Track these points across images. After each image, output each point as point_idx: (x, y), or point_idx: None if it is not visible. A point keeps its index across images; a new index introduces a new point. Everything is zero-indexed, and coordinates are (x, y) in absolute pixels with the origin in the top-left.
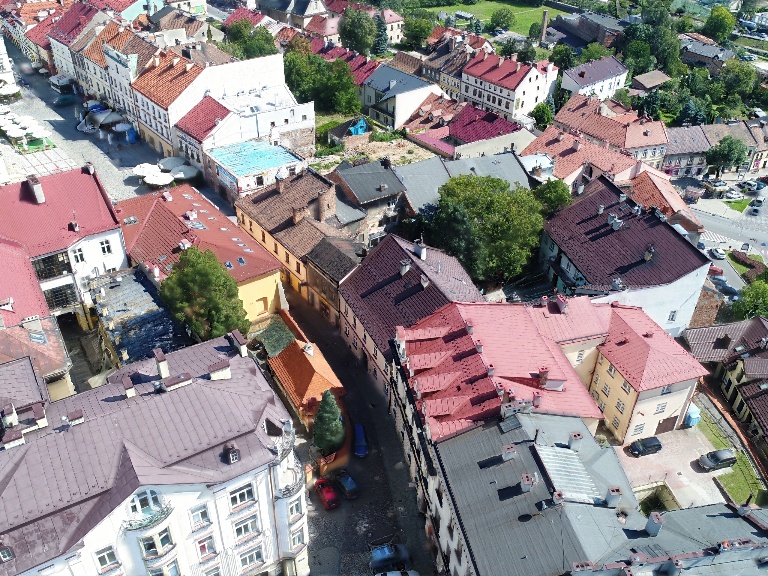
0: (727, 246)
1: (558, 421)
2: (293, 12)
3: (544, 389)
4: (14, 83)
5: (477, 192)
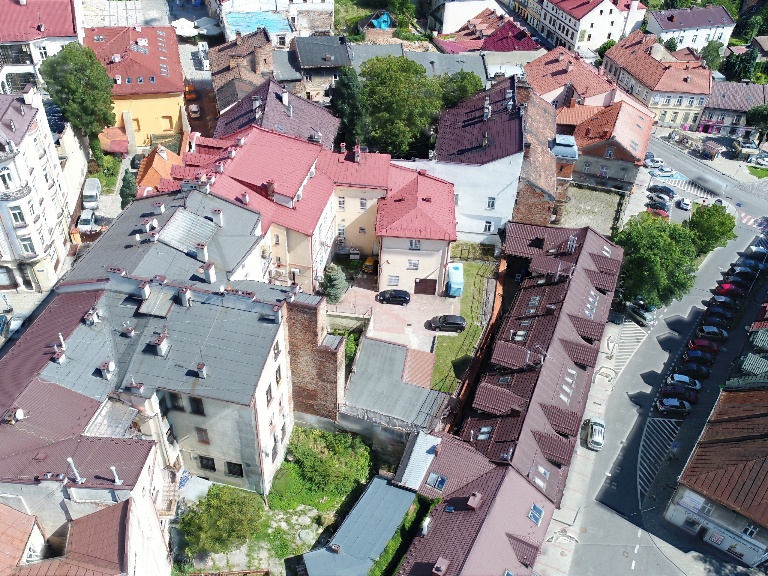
0: (705, 201)
1: (231, 208)
2: None
3: (275, 202)
4: None
5: (381, 66)
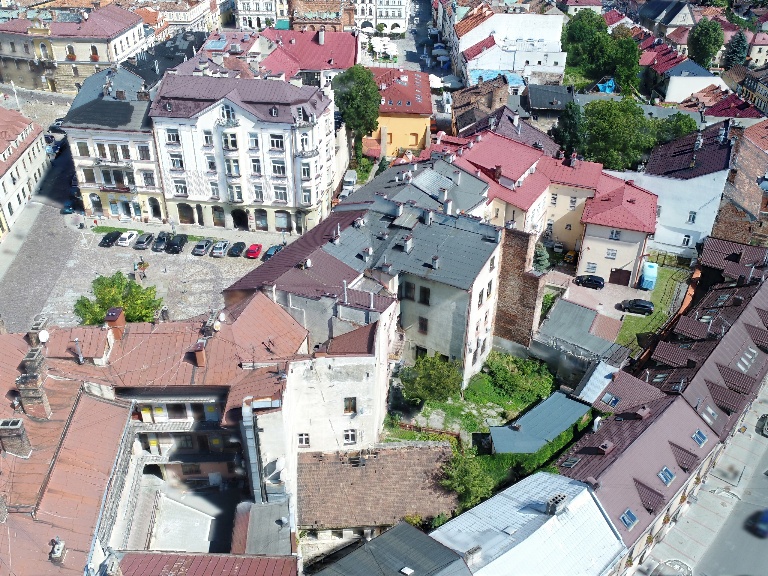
0: None
1: (467, 176)
2: (661, 21)
3: (500, 184)
4: (404, 28)
5: (603, 104)
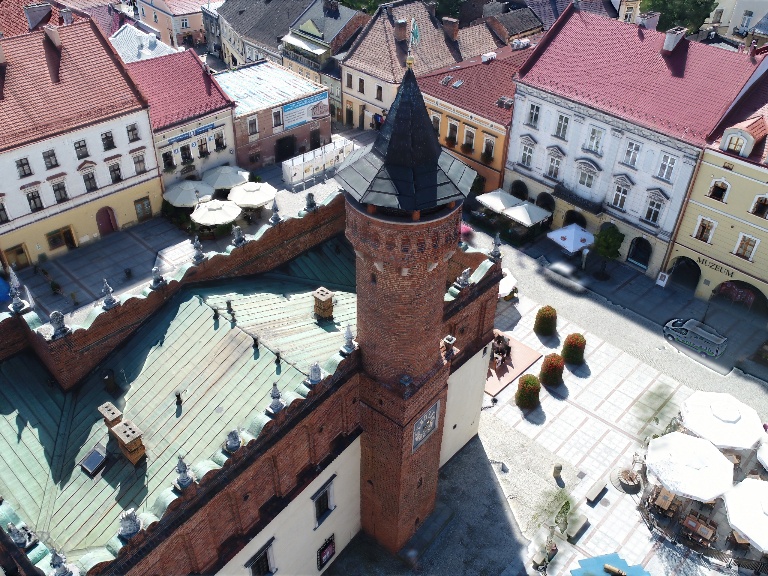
0: None
1: None
2: None
3: None
4: None
5: None
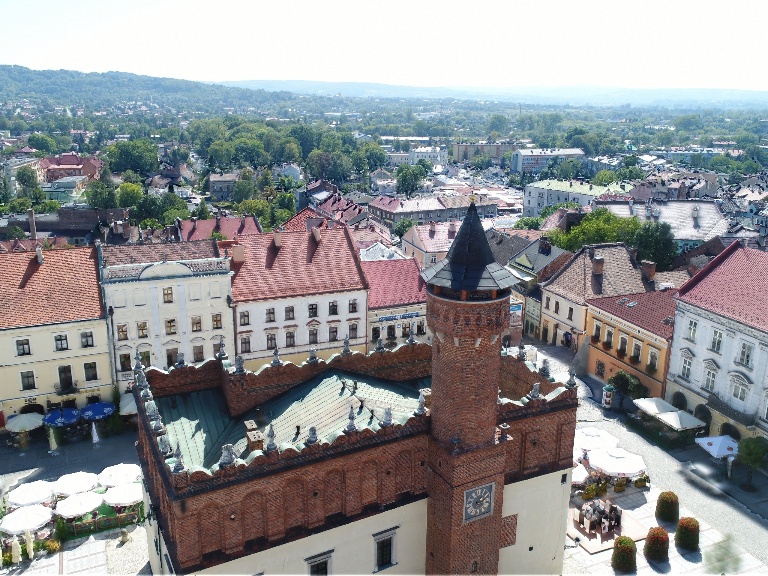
0: None
1: None
2: None
3: None
4: None
5: None
